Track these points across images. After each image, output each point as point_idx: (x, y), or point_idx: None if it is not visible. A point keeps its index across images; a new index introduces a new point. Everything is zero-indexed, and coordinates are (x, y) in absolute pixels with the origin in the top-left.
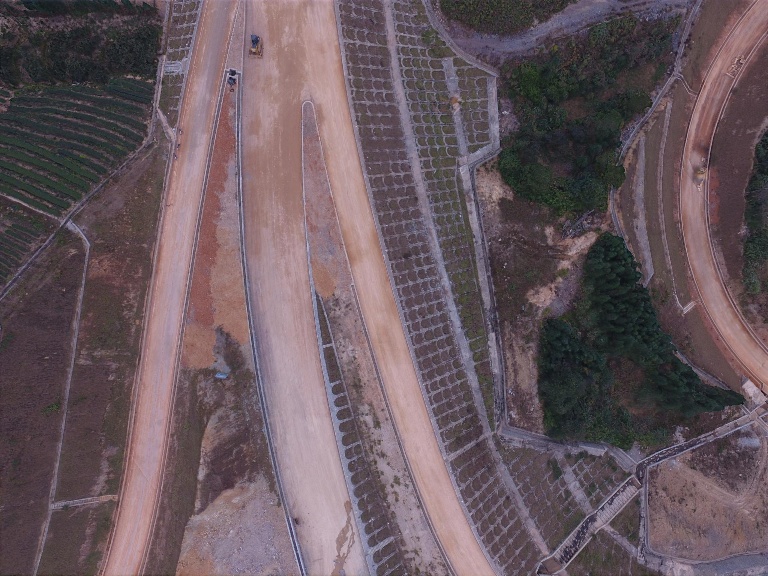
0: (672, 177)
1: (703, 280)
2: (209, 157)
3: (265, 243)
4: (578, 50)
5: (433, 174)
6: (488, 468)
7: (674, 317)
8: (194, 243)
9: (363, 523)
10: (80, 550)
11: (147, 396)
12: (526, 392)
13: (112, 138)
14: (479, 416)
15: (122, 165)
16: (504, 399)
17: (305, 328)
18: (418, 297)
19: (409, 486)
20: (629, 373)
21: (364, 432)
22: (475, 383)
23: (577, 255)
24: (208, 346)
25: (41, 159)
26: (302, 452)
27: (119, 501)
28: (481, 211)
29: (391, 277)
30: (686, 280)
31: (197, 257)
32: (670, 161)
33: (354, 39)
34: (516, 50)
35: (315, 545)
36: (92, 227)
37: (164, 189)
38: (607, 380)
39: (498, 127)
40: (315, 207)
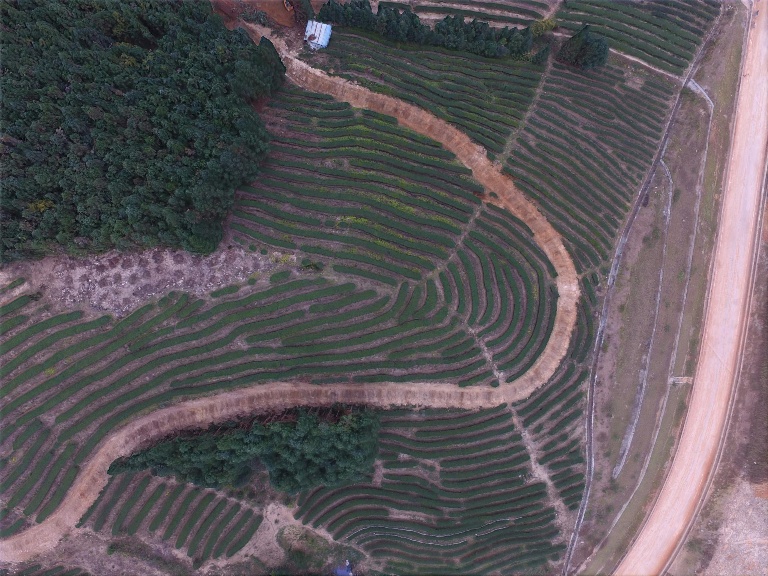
0: None
1: None
2: None
3: None
4: None
5: None
6: None
7: None
8: None
9: None
10: None
11: (722, 274)
12: None
13: (693, 3)
14: None
15: (712, 30)
16: None
17: None
18: None
19: None
20: None
21: None
22: None
23: None
24: None
25: (640, 21)
26: None
27: (693, 384)
28: None
29: None
30: None
31: None
32: None
33: None
34: None
35: None
36: (714, 87)
37: None
38: None
39: None
40: None
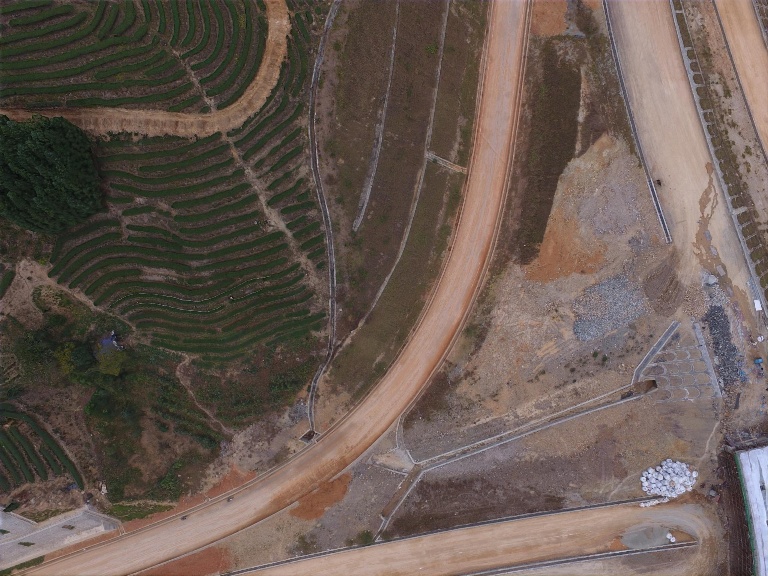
0: None
1: None
2: None
3: None
4: None
5: None
6: None
7: None
8: None
9: (725, 184)
10: (438, 216)
11: (494, 69)
12: None
13: None
14: None
15: None
16: None
17: None
18: None
19: (760, 157)
20: None
21: (715, 101)
22: None
23: None
24: (560, 13)
25: None
26: (660, 115)
27: (468, 175)
28: None
29: None
30: None
31: None
32: None
33: None
34: None
35: (677, 207)
36: None
37: None
38: None
39: None
40: None
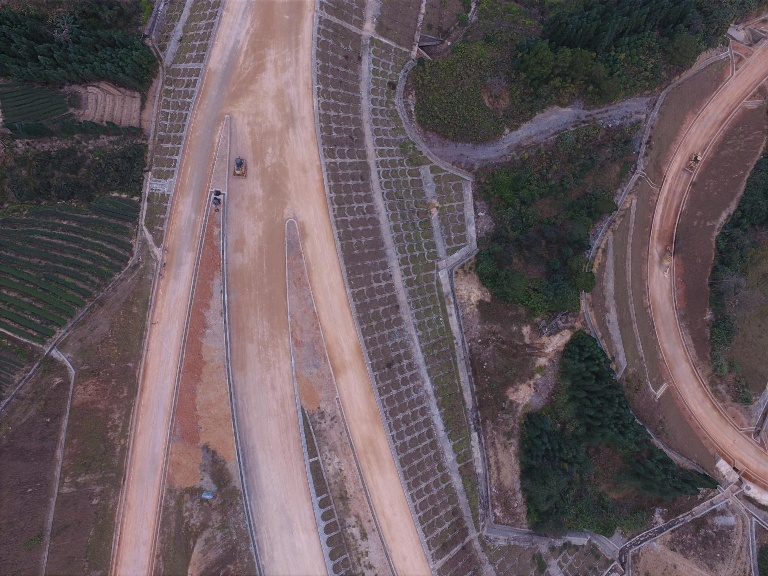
0: (640, 266)
1: (674, 362)
2: (194, 275)
3: (251, 359)
4: (547, 156)
5: (413, 281)
6: (475, 571)
7: (648, 403)
8: (180, 361)
9: None
10: None
11: (132, 516)
12: (509, 488)
13: (98, 259)
14: (464, 518)
15: (108, 287)
16: (488, 497)
17: (291, 443)
18: (402, 405)
19: None
20: (608, 459)
21: (351, 544)
22: (459, 485)
23: (553, 352)
24: (194, 464)
25: (26, 284)
26: (290, 569)
27: None
28: (460, 313)
29: (375, 389)
30: (658, 363)
31: (183, 375)
32: (637, 252)
33: (335, 158)
34: (489, 157)
35: None
36: (77, 354)
37: (150, 307)
38: (587, 469)
39: (474, 229)
40: (299, 322)
